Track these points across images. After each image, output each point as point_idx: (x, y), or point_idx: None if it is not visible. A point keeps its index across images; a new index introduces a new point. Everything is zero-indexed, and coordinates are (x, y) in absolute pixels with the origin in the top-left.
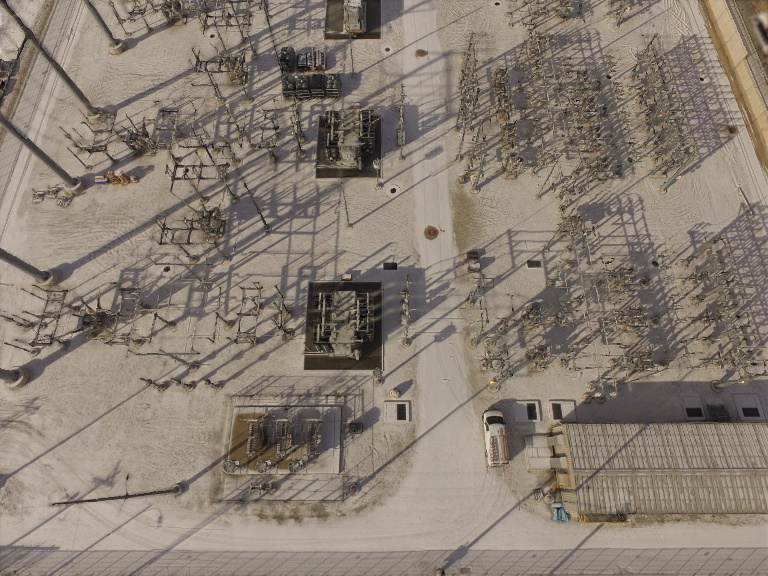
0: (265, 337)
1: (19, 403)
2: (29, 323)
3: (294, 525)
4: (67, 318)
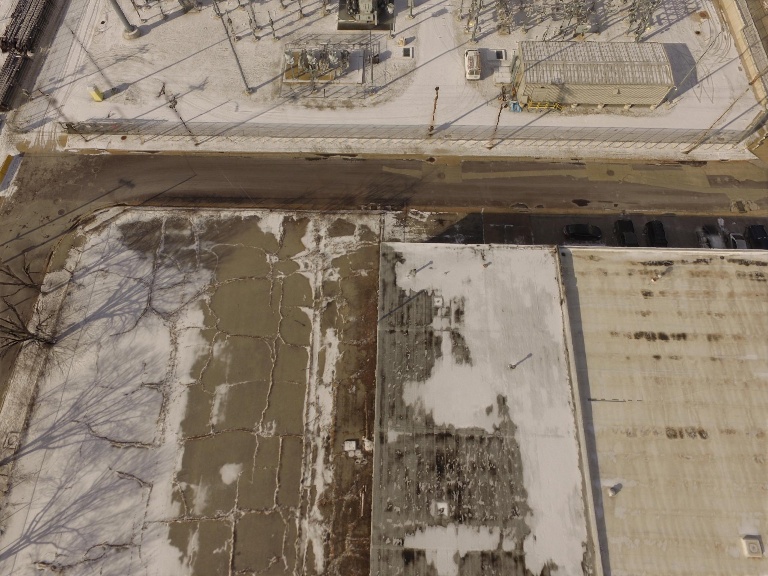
0: (309, 14)
1: (134, 47)
2: (138, 5)
3: (330, 111)
4: (165, 4)
